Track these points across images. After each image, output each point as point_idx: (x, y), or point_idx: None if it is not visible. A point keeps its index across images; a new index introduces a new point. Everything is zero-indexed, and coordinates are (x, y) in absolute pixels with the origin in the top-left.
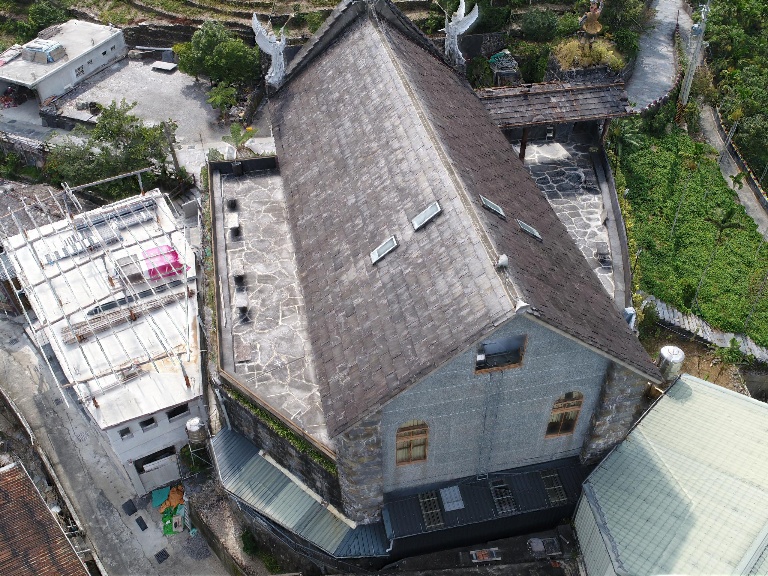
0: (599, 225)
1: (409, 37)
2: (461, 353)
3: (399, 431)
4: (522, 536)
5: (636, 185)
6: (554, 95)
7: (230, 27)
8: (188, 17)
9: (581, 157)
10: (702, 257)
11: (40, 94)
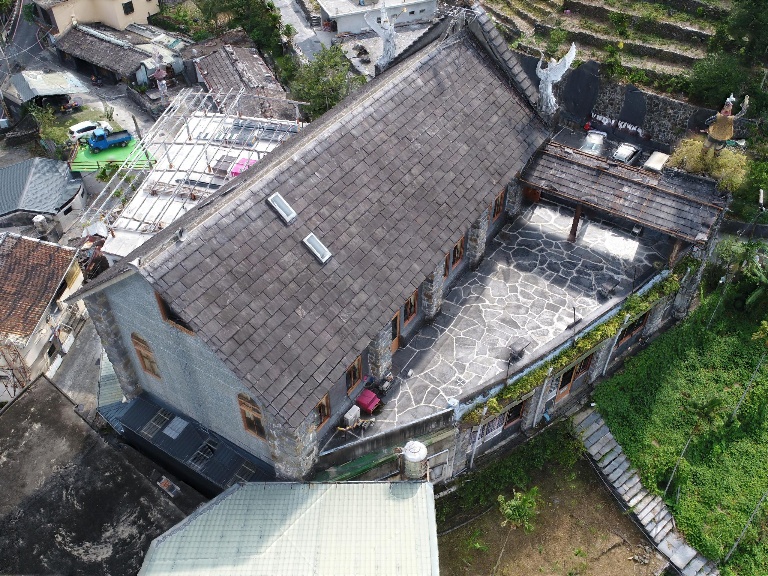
0: (561, 329)
1: (497, 66)
2: (114, 282)
3: (134, 338)
4: (204, 496)
5: (760, 346)
6: (630, 185)
7: (506, 22)
8: (486, 3)
9: (641, 266)
10: (763, 463)
11: (338, 27)
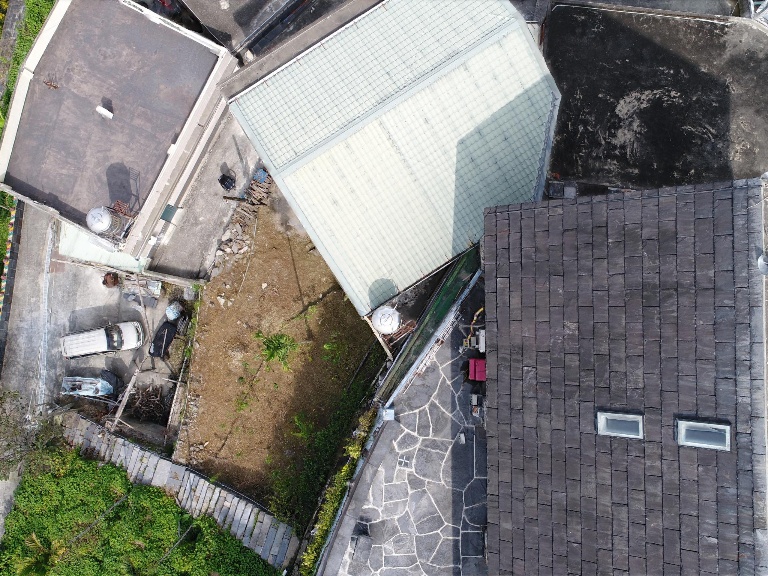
0: None
1: None
2: None
3: None
4: None
5: None
6: None
7: None
8: None
9: None
10: None
11: None
